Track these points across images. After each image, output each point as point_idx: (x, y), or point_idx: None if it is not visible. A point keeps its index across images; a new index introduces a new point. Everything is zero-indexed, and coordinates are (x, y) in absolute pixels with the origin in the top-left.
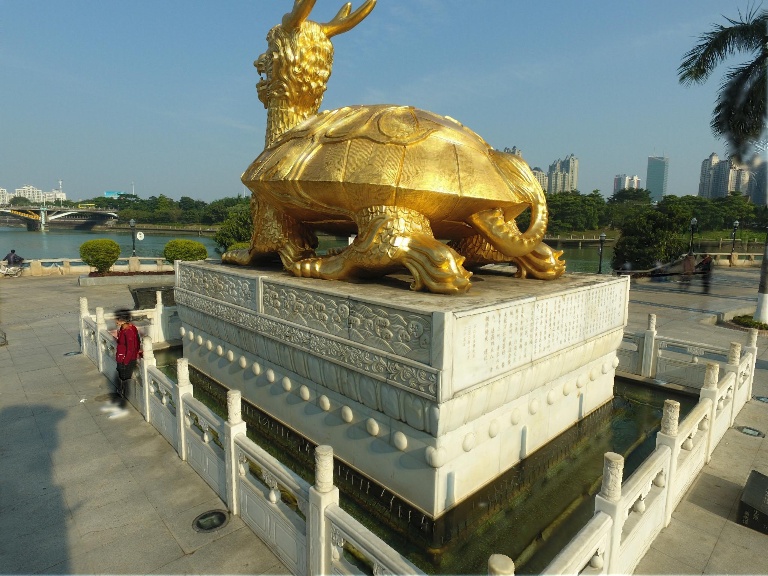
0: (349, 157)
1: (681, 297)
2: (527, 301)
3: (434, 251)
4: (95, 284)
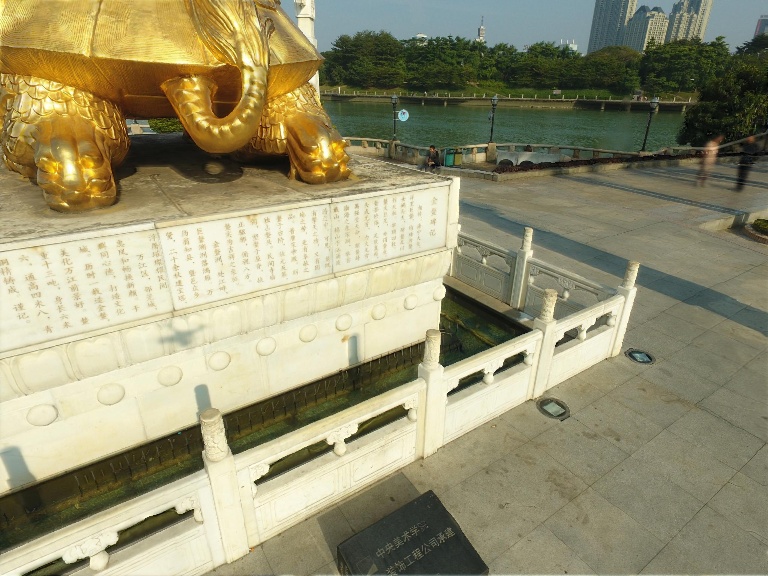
0: None
1: (715, 187)
2: (127, 230)
3: (39, 146)
4: None
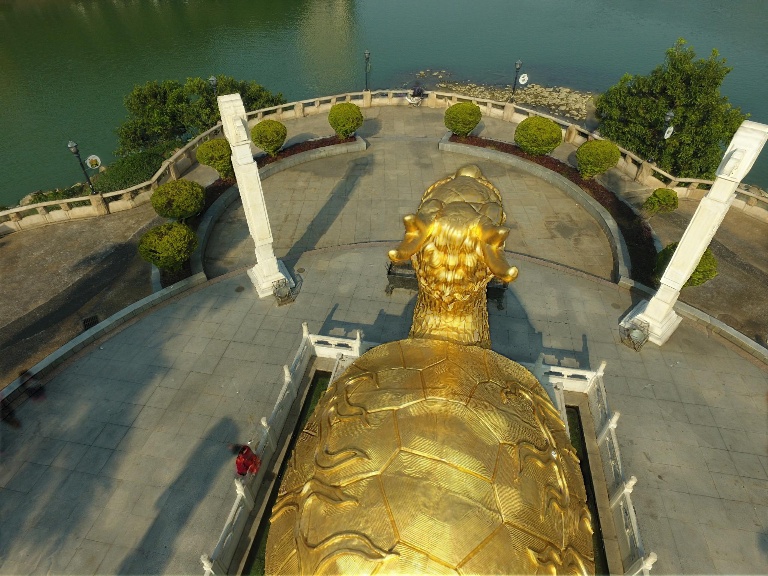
0: (281, 571)
1: None
2: None
3: None
4: (450, 150)
